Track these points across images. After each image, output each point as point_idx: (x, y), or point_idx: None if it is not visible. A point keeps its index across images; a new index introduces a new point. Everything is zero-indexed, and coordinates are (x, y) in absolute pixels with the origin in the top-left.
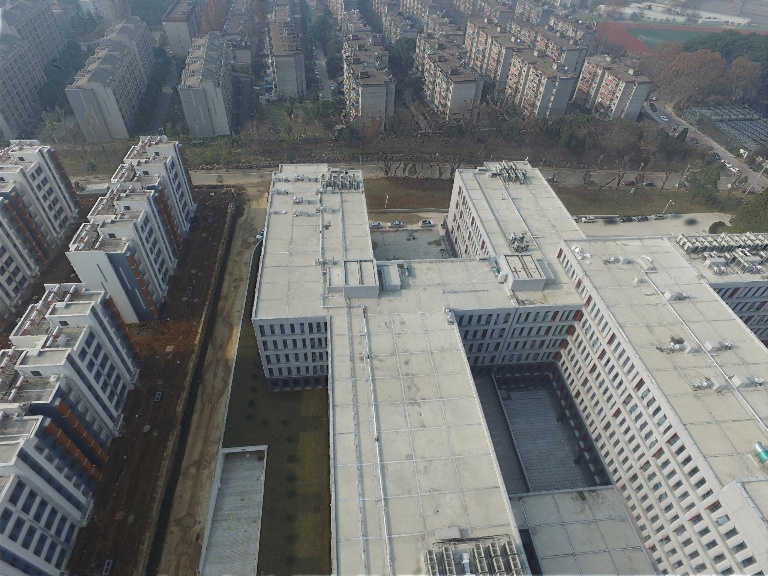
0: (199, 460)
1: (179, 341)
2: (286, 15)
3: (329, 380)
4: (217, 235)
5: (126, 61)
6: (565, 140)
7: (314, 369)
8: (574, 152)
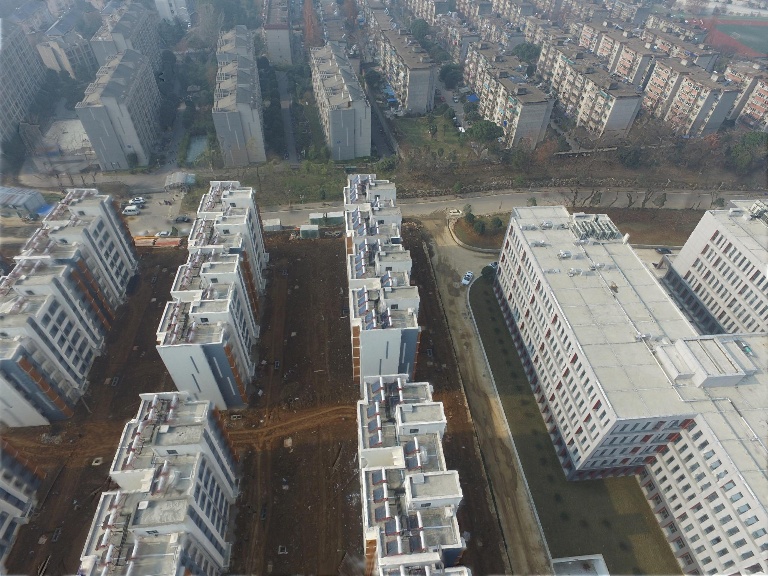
0: (531, 574)
1: (450, 419)
2: (388, 20)
3: (761, 508)
4: (429, 283)
5: (256, 77)
6: (748, 162)
7: (633, 460)
8: (752, 174)
